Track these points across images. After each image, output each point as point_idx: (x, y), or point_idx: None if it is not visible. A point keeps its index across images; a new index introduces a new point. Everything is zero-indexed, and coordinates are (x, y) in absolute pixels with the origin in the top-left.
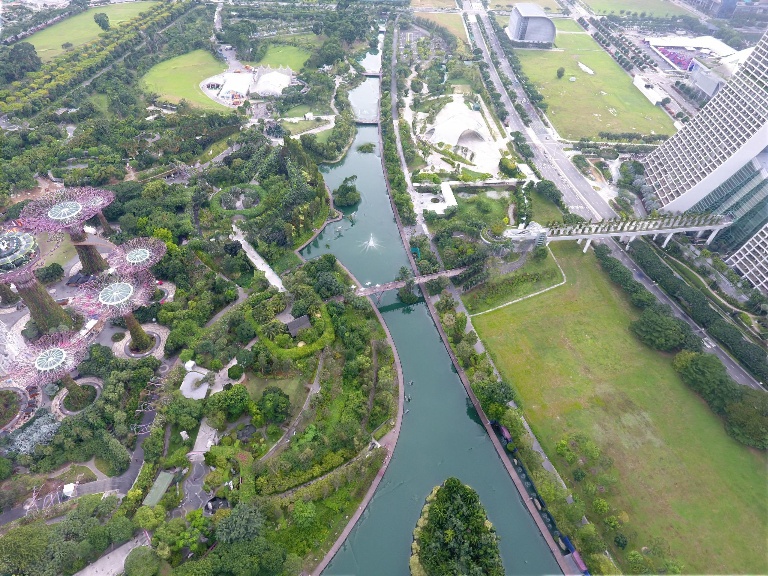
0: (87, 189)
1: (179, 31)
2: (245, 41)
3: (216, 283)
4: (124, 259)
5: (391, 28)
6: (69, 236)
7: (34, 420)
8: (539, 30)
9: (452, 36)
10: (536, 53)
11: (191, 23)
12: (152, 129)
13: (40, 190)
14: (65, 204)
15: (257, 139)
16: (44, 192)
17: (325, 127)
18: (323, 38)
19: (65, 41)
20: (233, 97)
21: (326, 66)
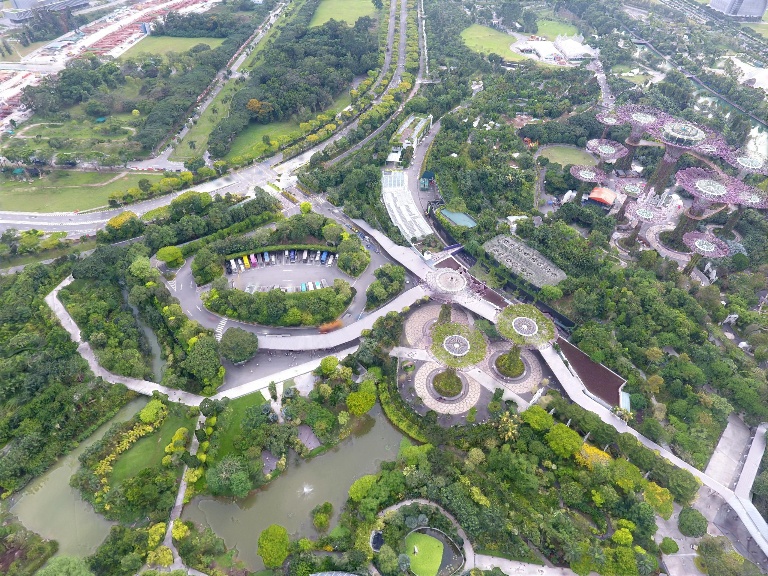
0: (639, 106)
1: (442, 9)
2: (535, 14)
3: (736, 172)
4: (701, 150)
5: (615, 6)
6: (572, 149)
7: (725, 241)
8: (752, 6)
9: (680, 11)
10: (752, 25)
11: (433, 3)
12: (533, 80)
13: (515, 120)
14: (639, 114)
15: (627, 86)
16: (521, 121)
17: (655, 80)
18: (559, 15)
19: (352, 18)
20: (555, 59)
21: (603, 35)
